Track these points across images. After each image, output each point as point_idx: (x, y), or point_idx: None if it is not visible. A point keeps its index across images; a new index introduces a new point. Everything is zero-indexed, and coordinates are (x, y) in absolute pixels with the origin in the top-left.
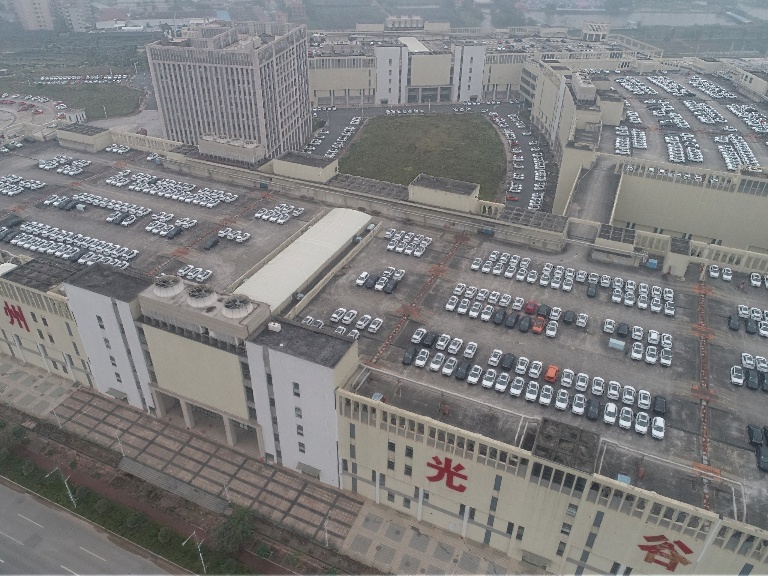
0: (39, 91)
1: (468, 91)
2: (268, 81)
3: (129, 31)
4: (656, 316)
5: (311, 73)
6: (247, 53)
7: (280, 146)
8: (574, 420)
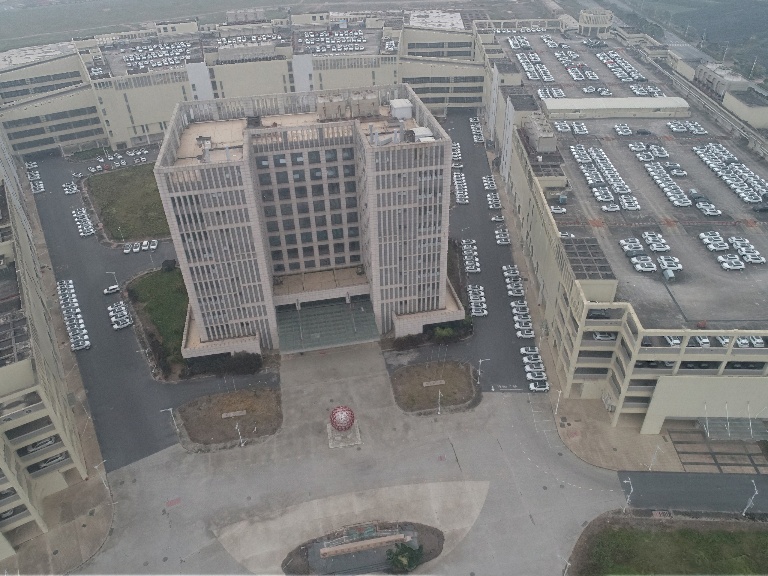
0: None
1: None
2: None
3: None
4: None
5: None
6: None
7: None
8: None
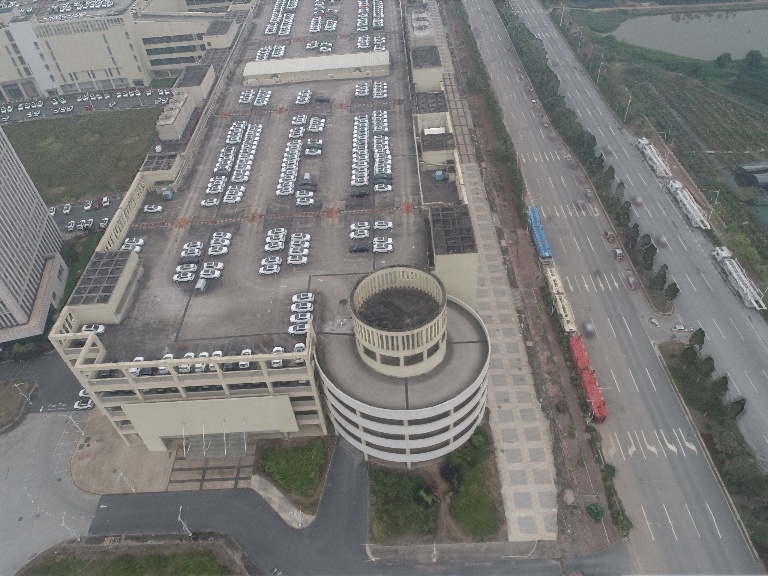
0: None
1: None
2: None
3: None
4: (301, 2)
5: None
6: None
7: None
8: (385, 3)
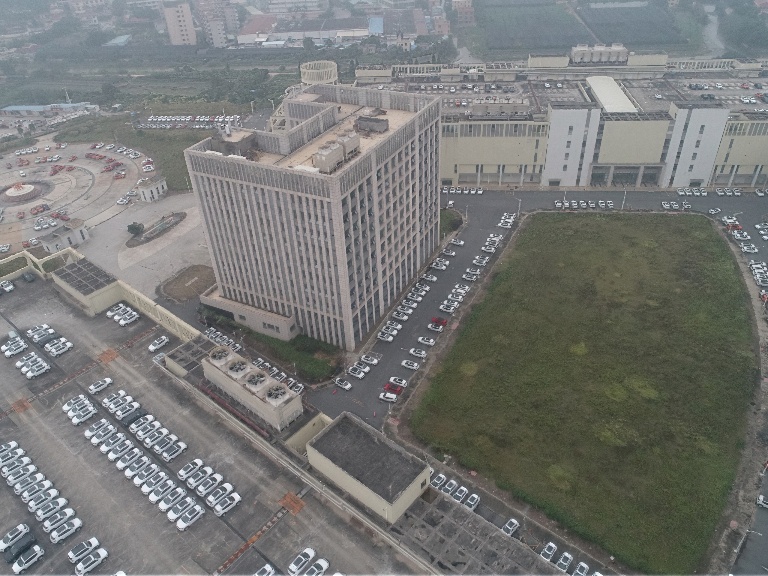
0: (137, 140)
1: (688, 173)
2: (359, 211)
3: (269, 47)
4: None
5: (452, 142)
6: (322, 178)
7: (377, 291)
8: None
